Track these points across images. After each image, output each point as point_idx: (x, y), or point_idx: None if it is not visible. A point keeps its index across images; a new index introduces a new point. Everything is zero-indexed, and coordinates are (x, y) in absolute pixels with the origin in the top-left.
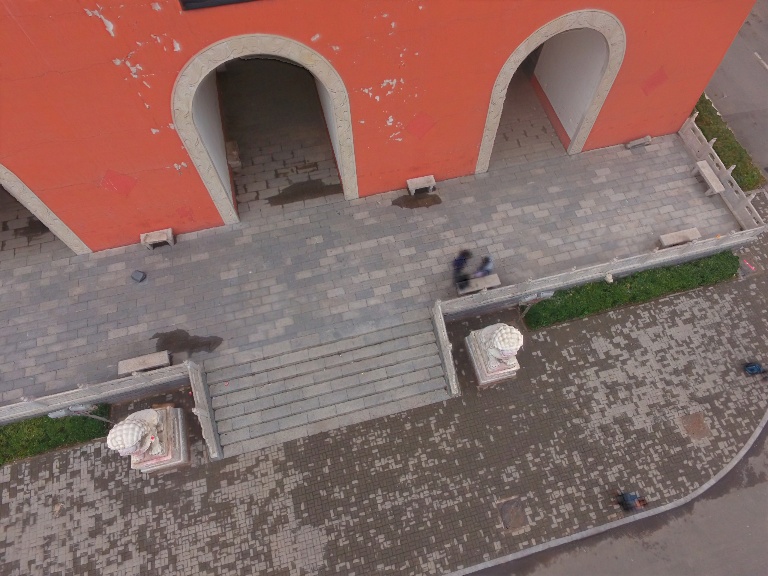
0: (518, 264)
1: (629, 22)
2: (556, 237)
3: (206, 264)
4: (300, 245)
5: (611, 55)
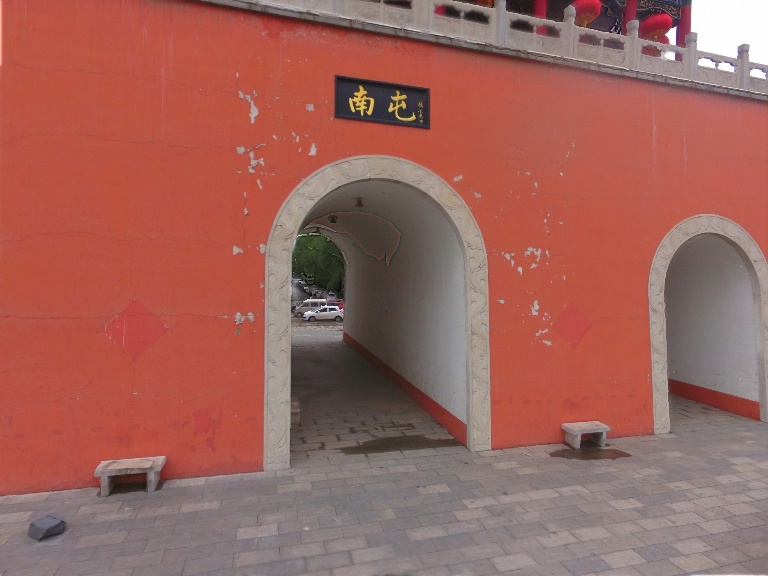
0: None
1: (759, 240)
2: None
3: (210, 516)
4: (407, 494)
5: (758, 275)
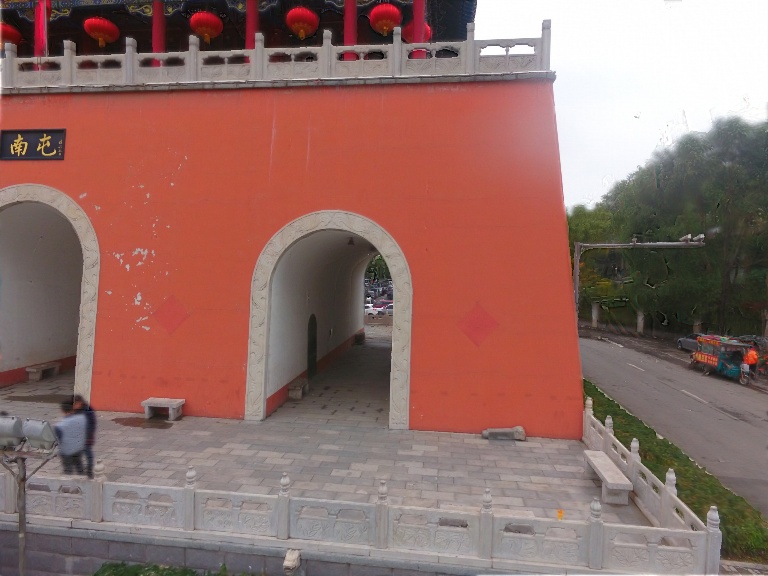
0: (157, 496)
1: (399, 234)
2: (265, 485)
3: None
4: None
5: (392, 271)
